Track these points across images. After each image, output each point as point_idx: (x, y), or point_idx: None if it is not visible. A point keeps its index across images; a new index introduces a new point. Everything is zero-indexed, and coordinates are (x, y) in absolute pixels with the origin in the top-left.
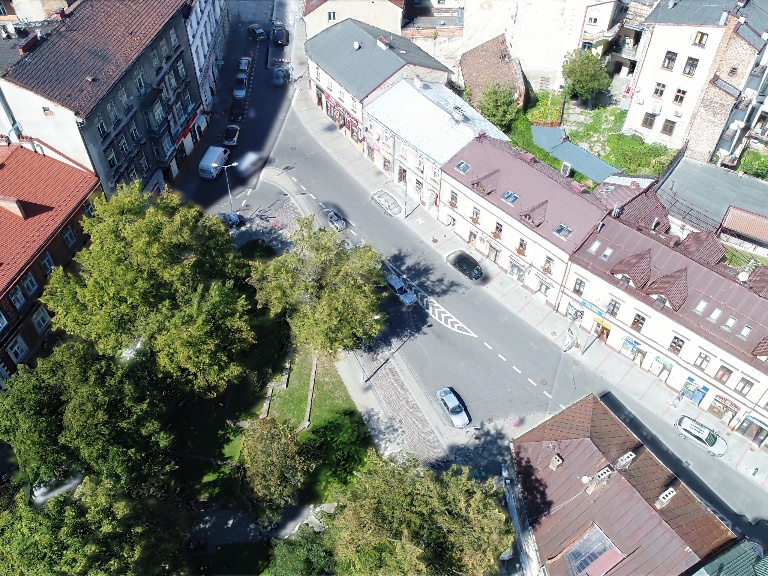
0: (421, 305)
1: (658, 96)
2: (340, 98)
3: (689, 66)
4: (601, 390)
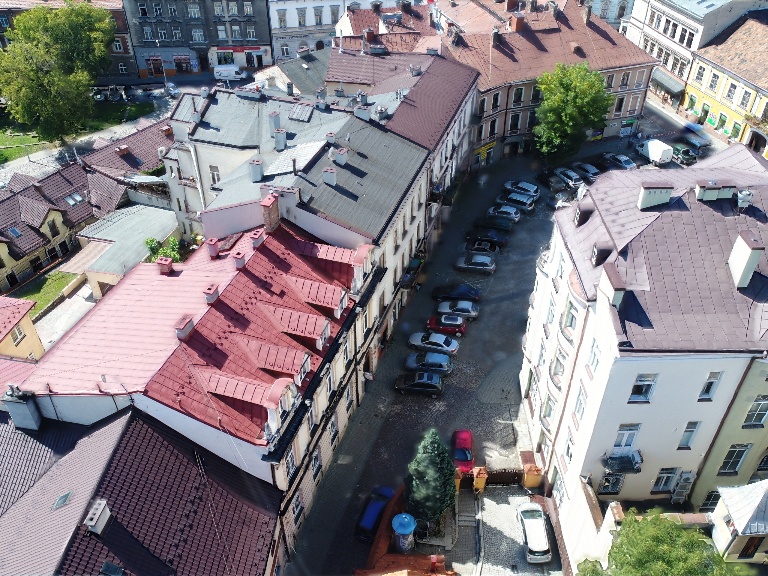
0: None
1: None
2: None
3: None
4: None
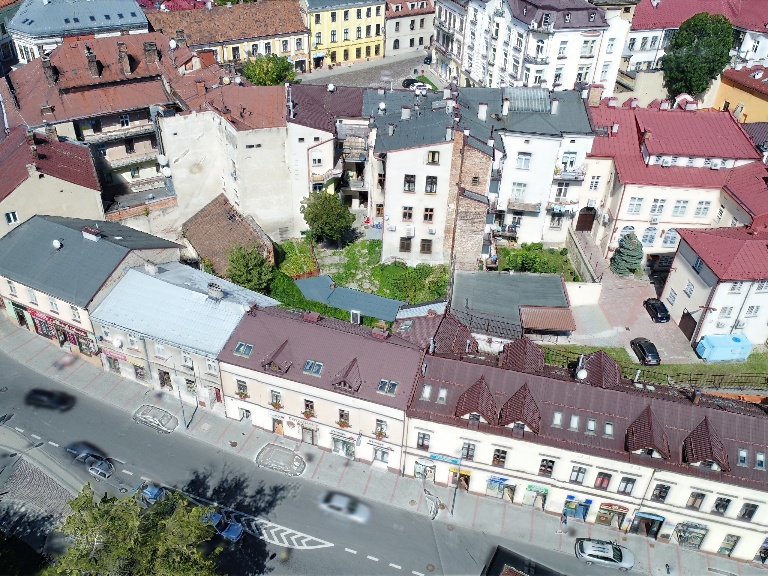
0: (251, 533)
1: (408, 219)
2: (52, 310)
3: (429, 185)
4: (490, 548)
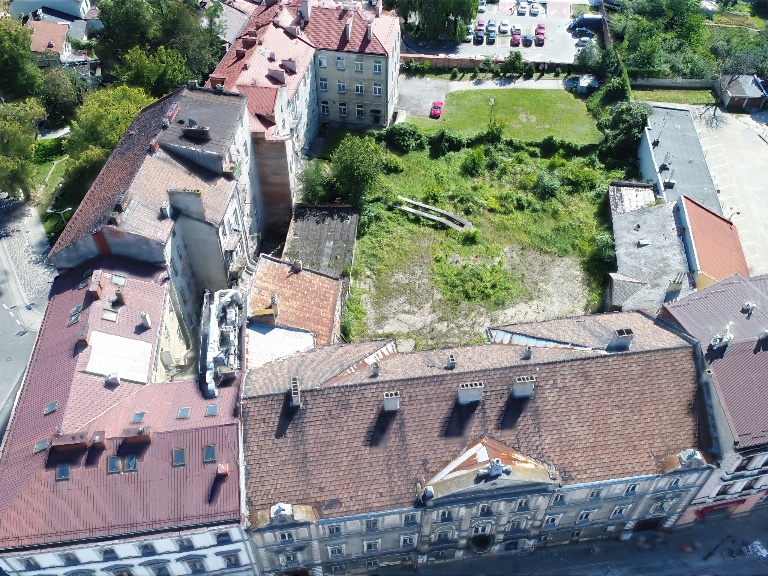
0: None
1: None
2: None
3: None
4: None
